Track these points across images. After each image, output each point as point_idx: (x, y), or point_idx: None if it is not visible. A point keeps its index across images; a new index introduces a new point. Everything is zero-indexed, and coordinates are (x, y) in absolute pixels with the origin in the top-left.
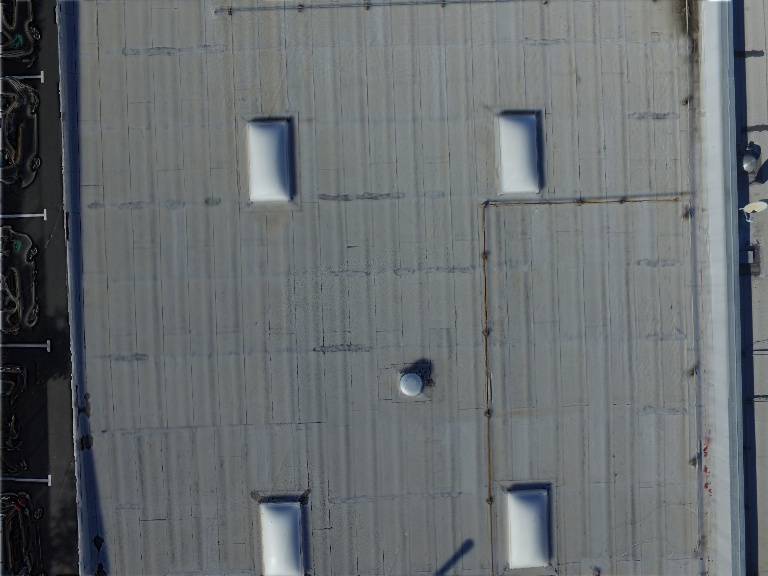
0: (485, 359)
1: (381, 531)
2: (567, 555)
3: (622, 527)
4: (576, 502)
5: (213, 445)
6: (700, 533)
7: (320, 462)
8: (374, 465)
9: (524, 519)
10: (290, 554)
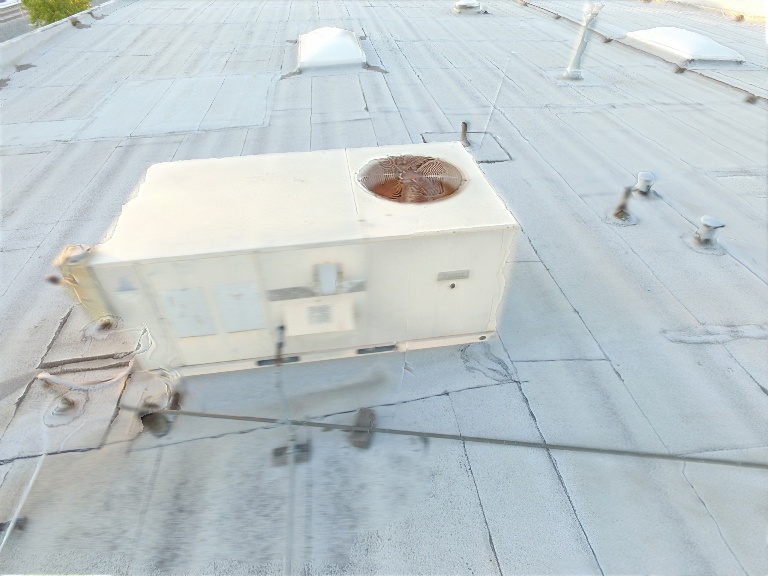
0: (534, 8)
1: None
2: (762, 63)
3: None
4: None
5: (243, 28)
6: None
7: (378, 29)
8: None
9: (664, 30)
10: (344, 39)
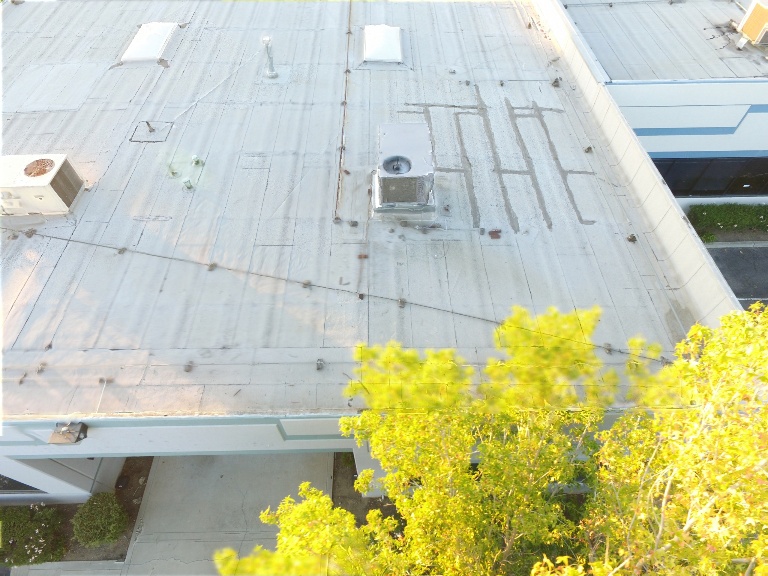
0: None
1: (246, 43)
2: (422, 62)
3: (473, 52)
4: (428, 39)
5: None
6: (550, 58)
7: (206, 12)
8: (251, 15)
9: (377, 29)
10: (154, 38)
